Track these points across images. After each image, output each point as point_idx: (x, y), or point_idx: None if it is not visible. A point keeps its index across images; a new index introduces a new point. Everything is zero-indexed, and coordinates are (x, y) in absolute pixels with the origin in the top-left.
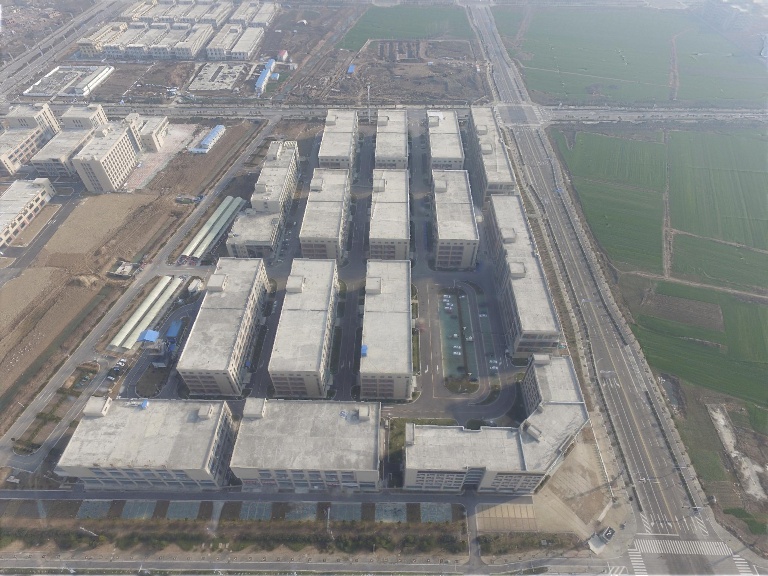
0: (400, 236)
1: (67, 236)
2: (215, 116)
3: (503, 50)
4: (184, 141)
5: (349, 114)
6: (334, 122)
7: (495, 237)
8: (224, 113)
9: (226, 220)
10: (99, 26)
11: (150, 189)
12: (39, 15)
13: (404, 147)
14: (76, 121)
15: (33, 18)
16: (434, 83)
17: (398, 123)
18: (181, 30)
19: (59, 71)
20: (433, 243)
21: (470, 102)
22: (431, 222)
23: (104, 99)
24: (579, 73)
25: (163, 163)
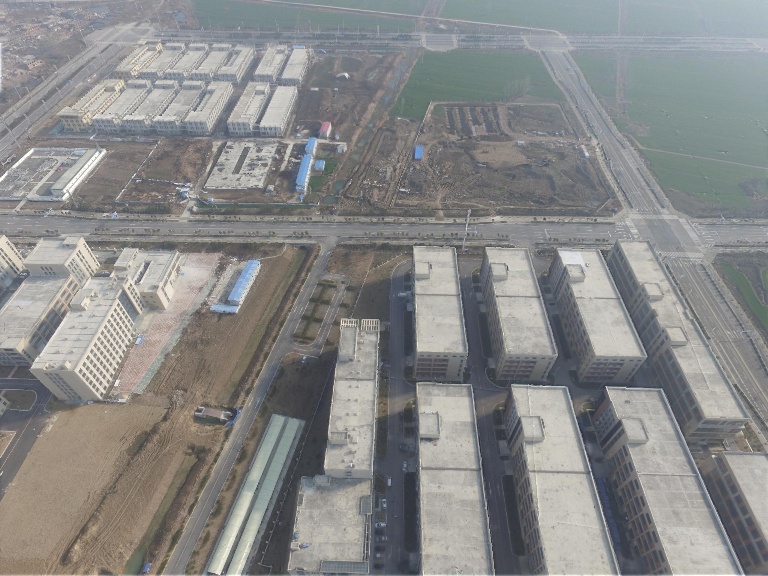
0: (602, 573)
1: (18, 512)
2: (244, 238)
3: (607, 120)
4: (203, 288)
5: (445, 255)
6: (428, 275)
7: (755, 555)
8: (257, 234)
9: (278, 476)
10: (89, 81)
11: (154, 393)
12: (16, 65)
13: (545, 329)
14: (45, 268)
15: (8, 69)
16: (534, 177)
17: (521, 275)
18: (193, 90)
19: (33, 156)
20: (626, 533)
21: (592, 211)
22: (608, 477)
23: (91, 207)
24: (720, 159)
25: (173, 335)
